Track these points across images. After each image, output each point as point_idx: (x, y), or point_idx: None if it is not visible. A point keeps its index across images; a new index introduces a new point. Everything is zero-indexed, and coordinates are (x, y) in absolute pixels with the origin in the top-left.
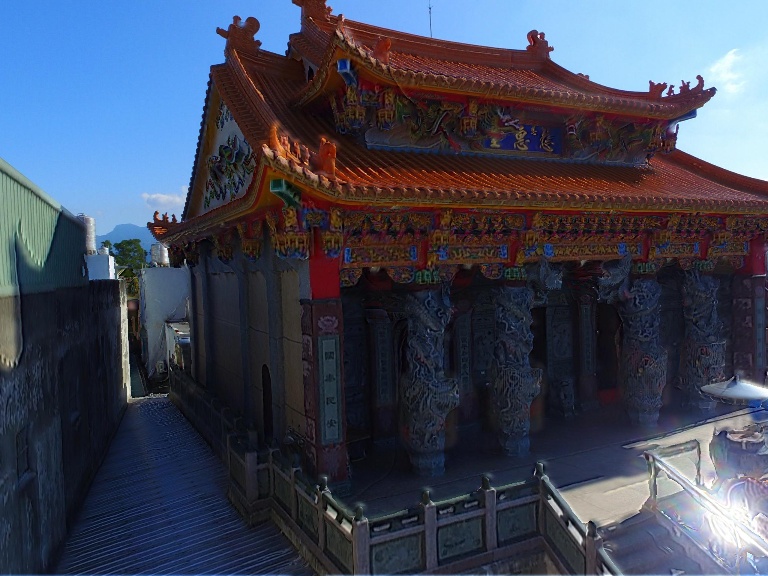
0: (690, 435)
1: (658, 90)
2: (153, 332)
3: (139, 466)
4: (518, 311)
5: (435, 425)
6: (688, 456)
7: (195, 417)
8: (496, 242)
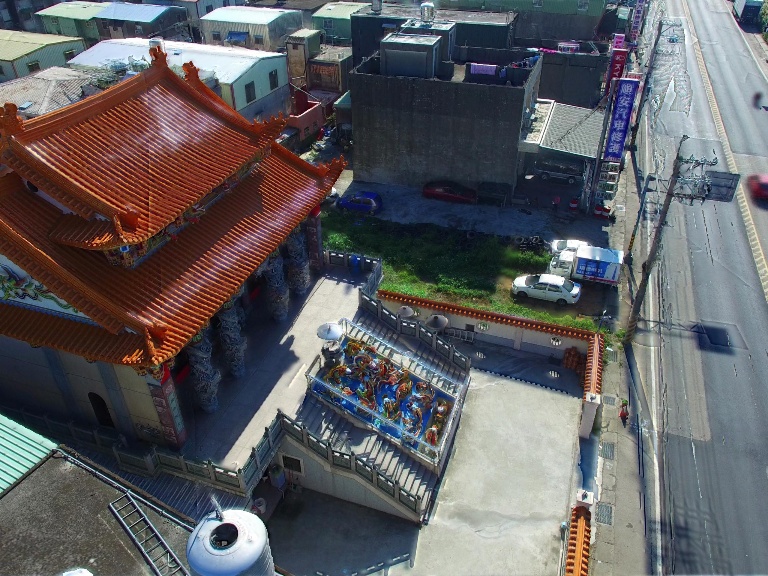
0: (303, 320)
1: (260, 128)
2: None
3: None
4: None
5: None
6: None
7: None
8: None
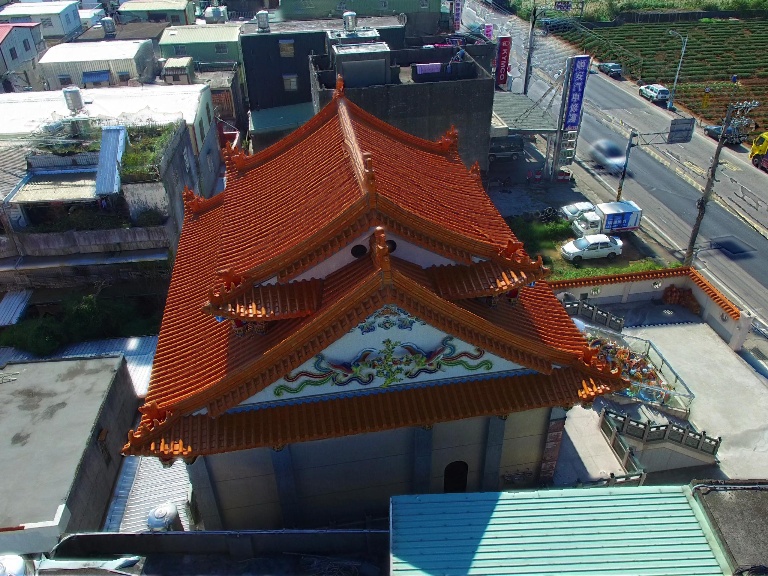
0: None
1: None
2: None
3: None
4: None
5: None
6: None
7: None
8: None
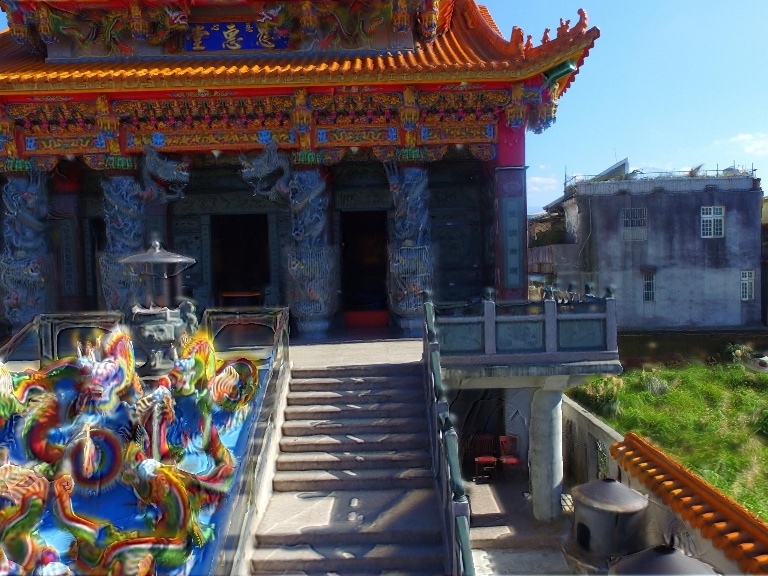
0: (324, 346)
1: None
2: None
3: None
4: (110, 199)
5: (10, 298)
6: (107, 328)
7: None
8: (91, 132)
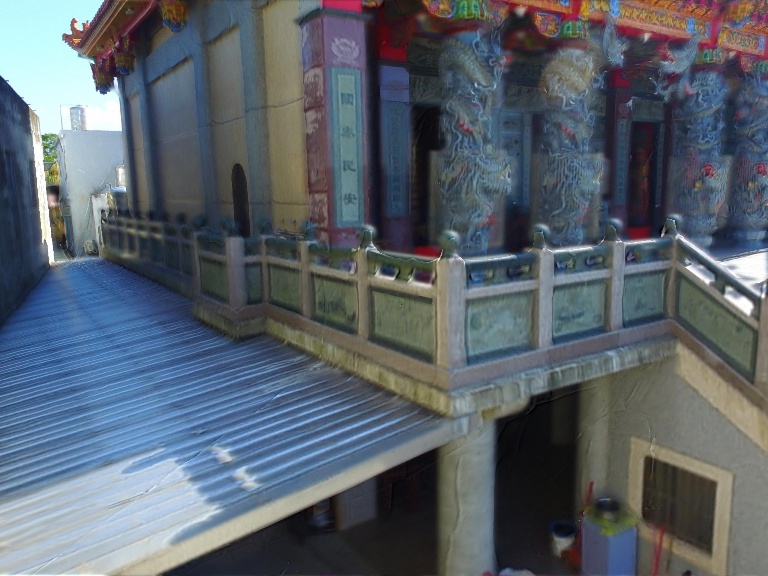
0: (751, 259)
1: None
2: (77, 208)
3: (68, 307)
4: (580, 80)
5: (481, 216)
6: None
7: (139, 260)
8: None
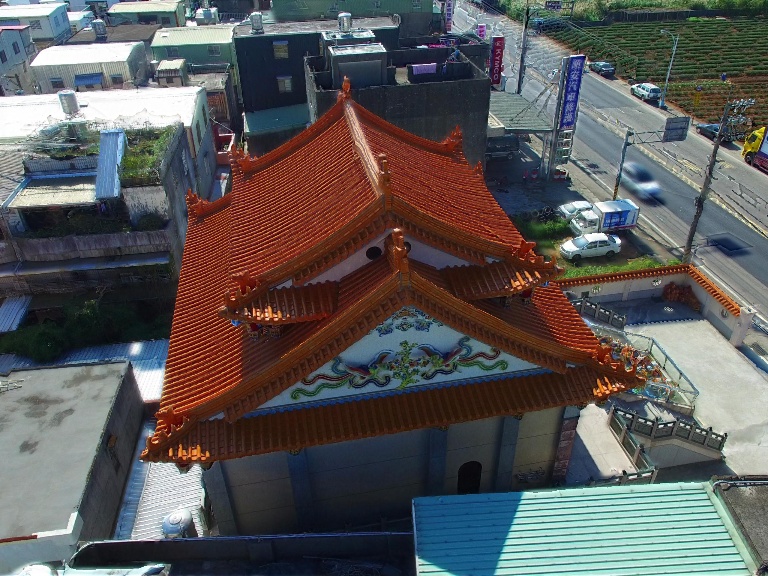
0: None
1: None
2: None
3: None
4: None
5: None
6: None
7: None
8: None
